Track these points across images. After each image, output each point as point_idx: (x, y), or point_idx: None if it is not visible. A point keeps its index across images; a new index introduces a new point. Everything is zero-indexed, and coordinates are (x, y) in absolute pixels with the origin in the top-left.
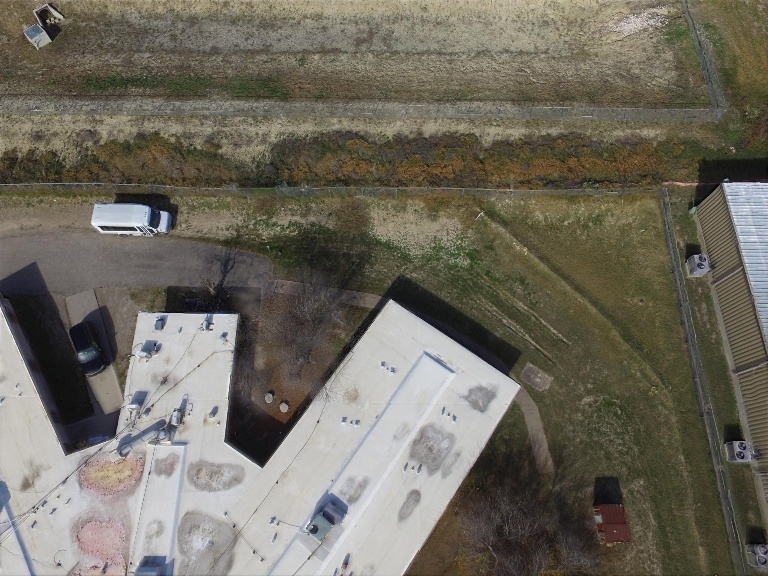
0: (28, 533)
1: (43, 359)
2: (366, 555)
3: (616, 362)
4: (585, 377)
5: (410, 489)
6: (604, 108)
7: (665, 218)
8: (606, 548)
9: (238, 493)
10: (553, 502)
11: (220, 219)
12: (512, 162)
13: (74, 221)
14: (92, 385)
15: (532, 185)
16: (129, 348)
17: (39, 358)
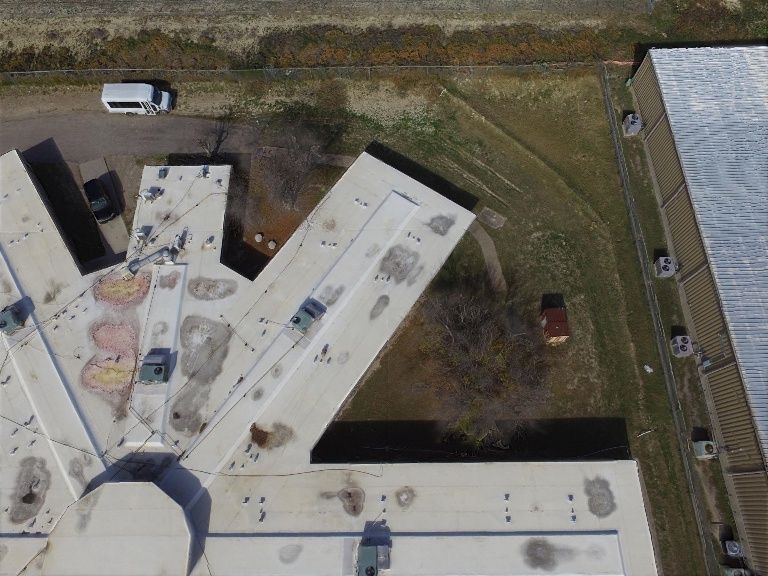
0: (51, 335)
1: (60, 210)
2: (342, 345)
3: (561, 205)
4: (534, 217)
5: (380, 294)
6: None
7: (605, 90)
8: (551, 347)
9: (232, 301)
10: (506, 313)
11: (215, 100)
12: (471, 47)
13: (85, 105)
14: (104, 231)
15: (488, 65)
16: None
17: (57, 208)
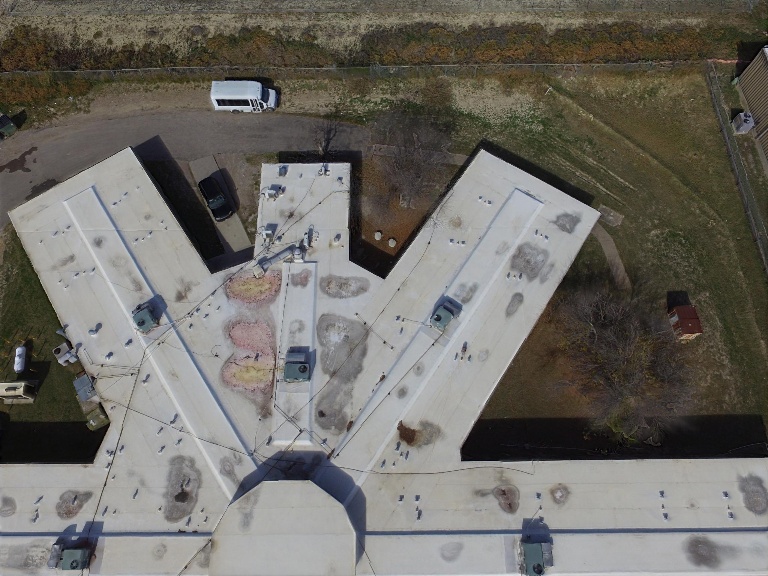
0: (186, 333)
1: (177, 208)
2: (481, 342)
3: (677, 203)
4: (651, 215)
5: (514, 292)
6: None
7: (711, 88)
8: (681, 345)
9: (366, 298)
10: None
11: (319, 98)
12: (575, 45)
13: (189, 102)
14: (221, 229)
15: (594, 63)
16: (250, 200)
17: None
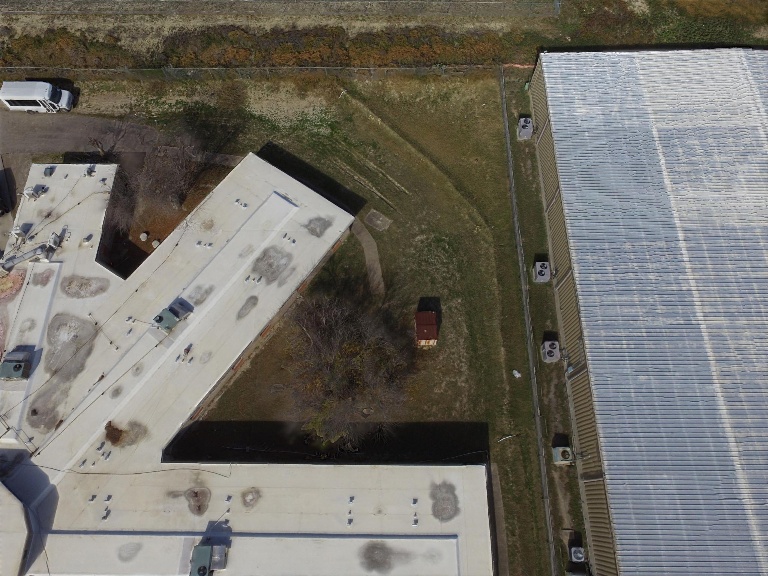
0: None
1: None
2: (206, 345)
3: (449, 208)
4: (420, 220)
5: (249, 295)
6: (453, 2)
7: (503, 94)
8: (423, 351)
9: (102, 299)
10: (381, 316)
11: (116, 99)
12: (372, 49)
13: None
14: None
15: (388, 67)
16: None
17: None
